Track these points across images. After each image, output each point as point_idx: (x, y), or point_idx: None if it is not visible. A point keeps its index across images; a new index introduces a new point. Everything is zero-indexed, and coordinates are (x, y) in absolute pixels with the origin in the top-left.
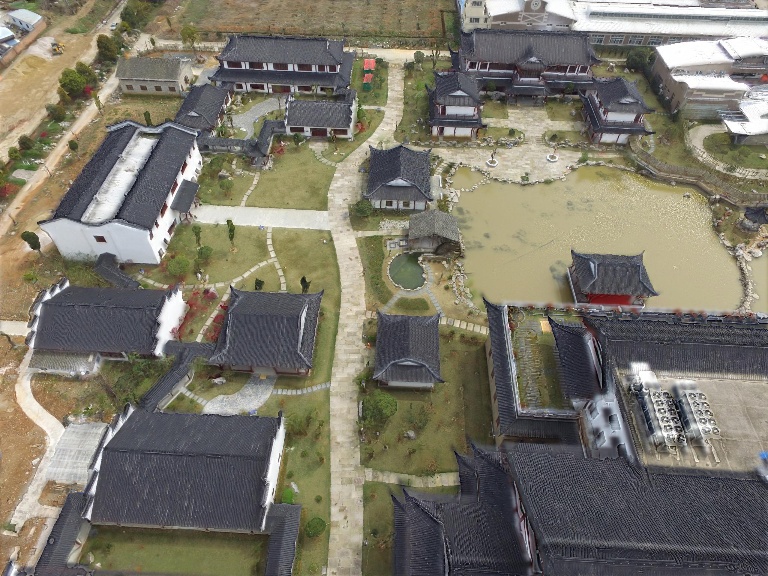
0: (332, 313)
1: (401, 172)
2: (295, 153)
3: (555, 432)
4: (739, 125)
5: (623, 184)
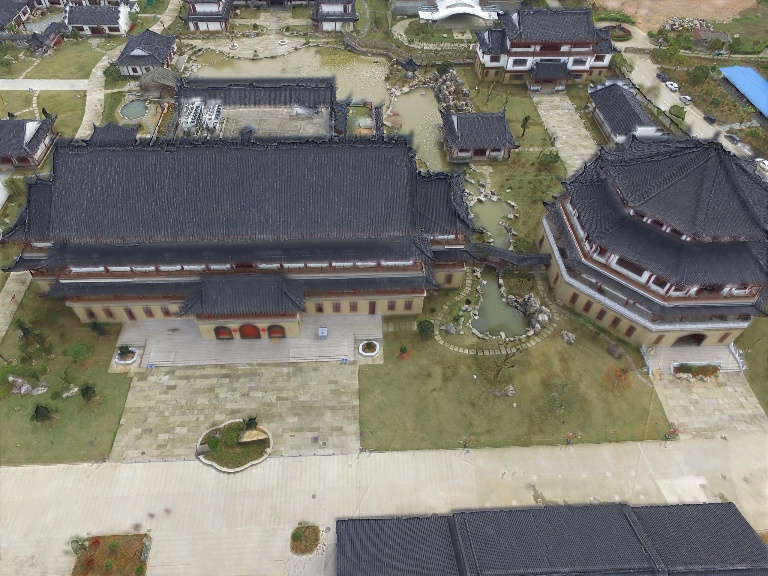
0: (70, 136)
1: (141, 45)
2: (74, 45)
3: None
4: (429, 14)
5: (331, 57)
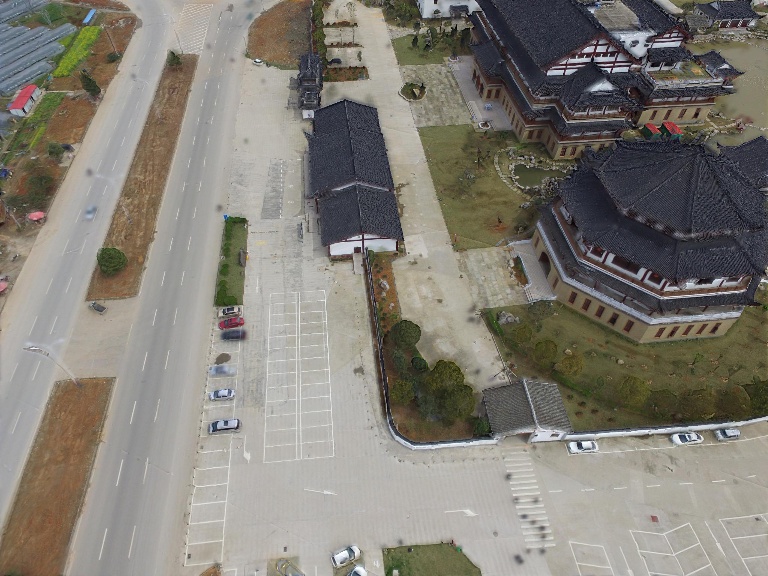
0: None
1: (724, 2)
2: None
3: None
4: None
5: None
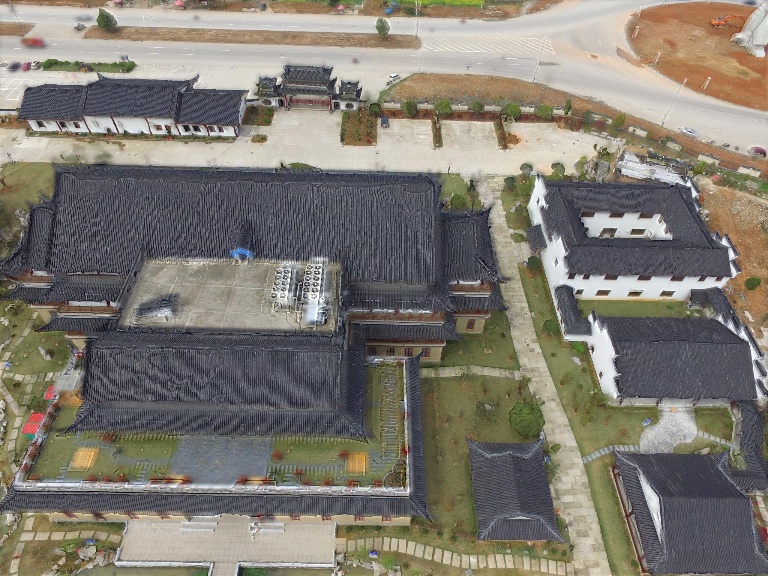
0: (621, 569)
1: None
2: None
3: (370, 360)
4: None
5: None
